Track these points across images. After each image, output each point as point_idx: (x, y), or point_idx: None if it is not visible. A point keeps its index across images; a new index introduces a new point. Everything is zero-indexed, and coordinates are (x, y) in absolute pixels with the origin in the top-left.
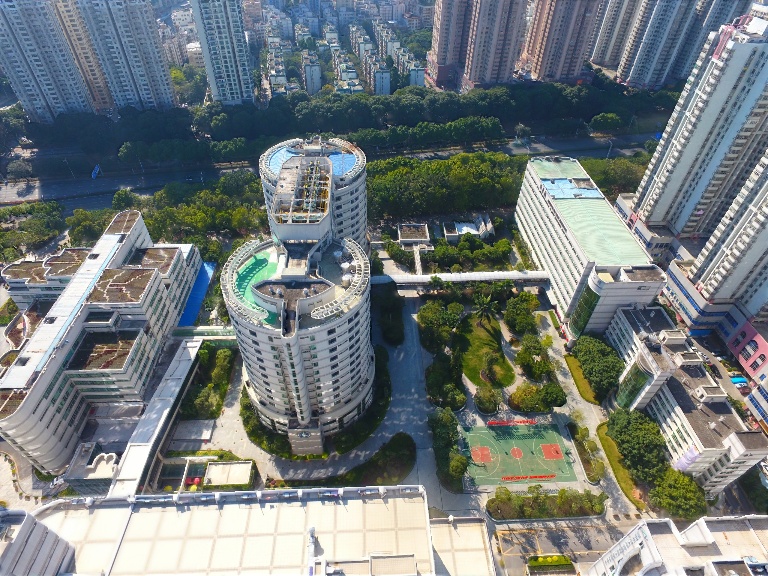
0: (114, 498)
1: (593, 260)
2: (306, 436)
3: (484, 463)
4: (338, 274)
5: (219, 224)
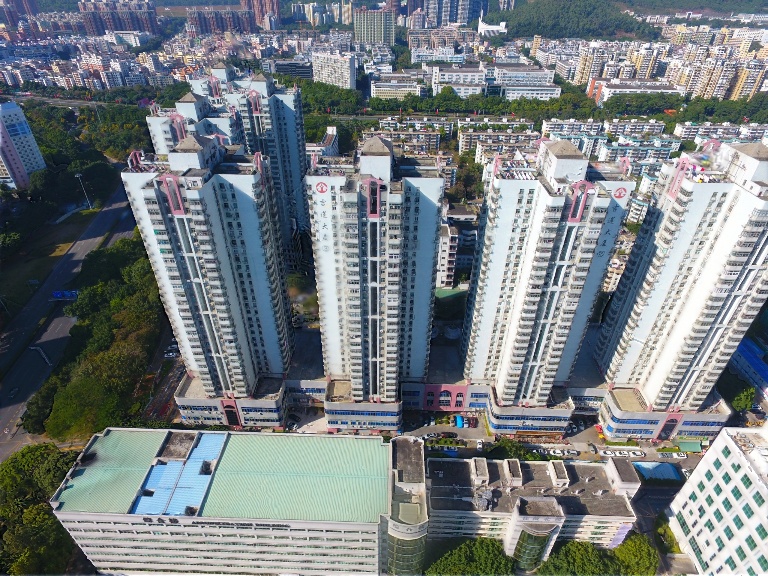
0: None
1: (376, 516)
2: None
3: None
4: None
5: None
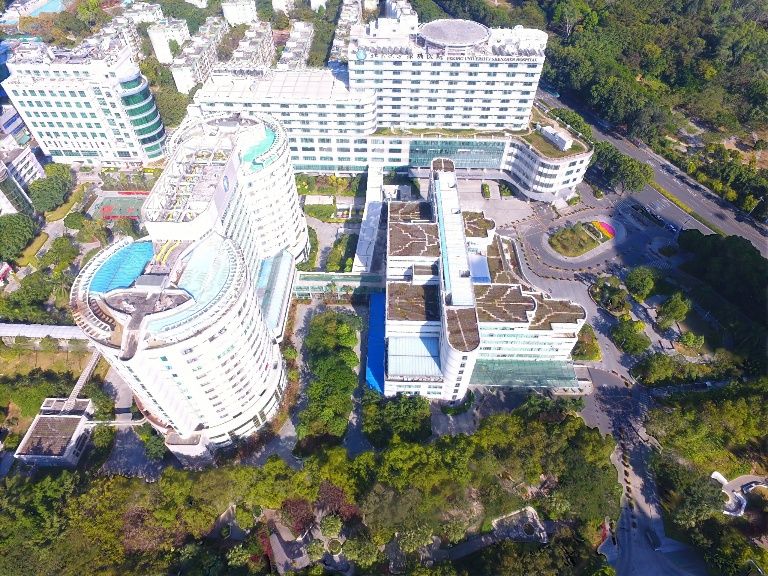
0: (340, 101)
1: None
2: None
3: None
4: None
5: None
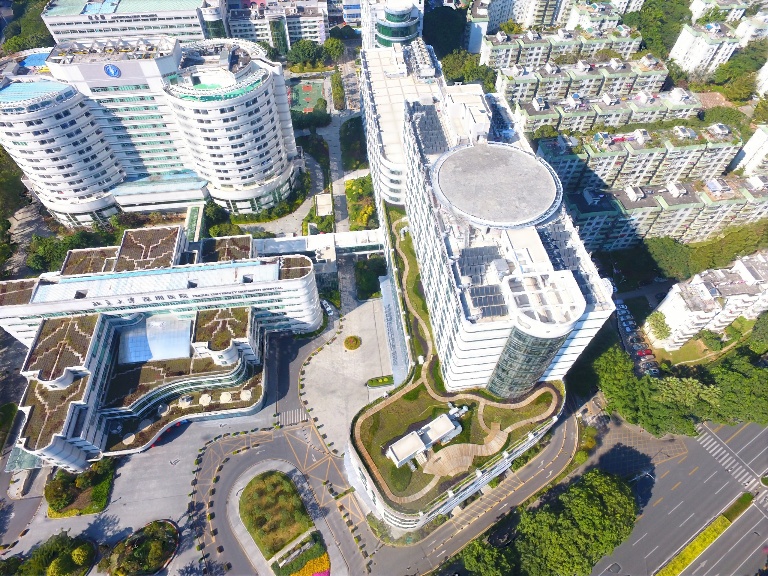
0: None
1: (195, 8)
2: None
3: None
4: None
5: None
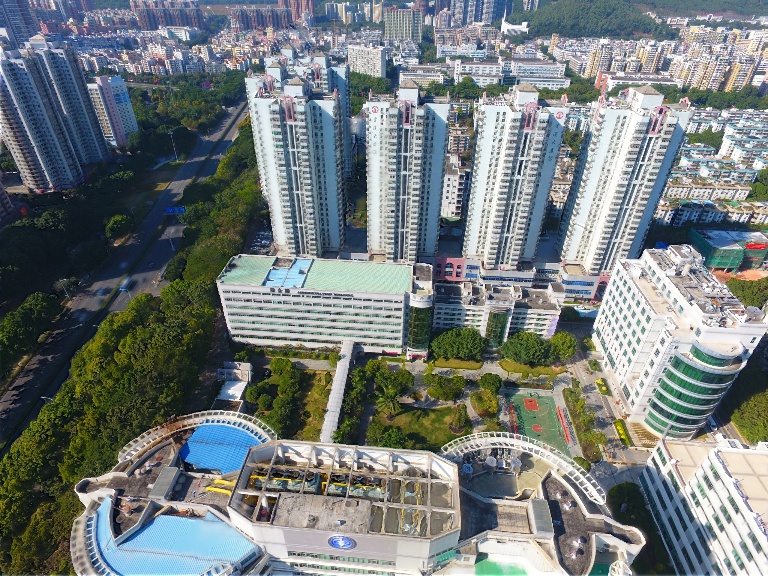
0: None
1: (403, 292)
2: None
3: None
4: (494, 478)
5: None
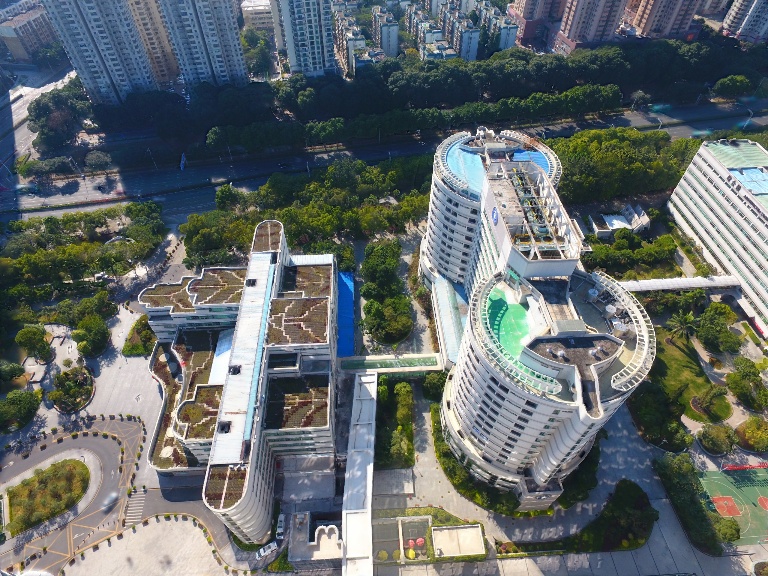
0: None
1: None
2: (544, 498)
3: (733, 517)
4: (599, 319)
5: (347, 226)
